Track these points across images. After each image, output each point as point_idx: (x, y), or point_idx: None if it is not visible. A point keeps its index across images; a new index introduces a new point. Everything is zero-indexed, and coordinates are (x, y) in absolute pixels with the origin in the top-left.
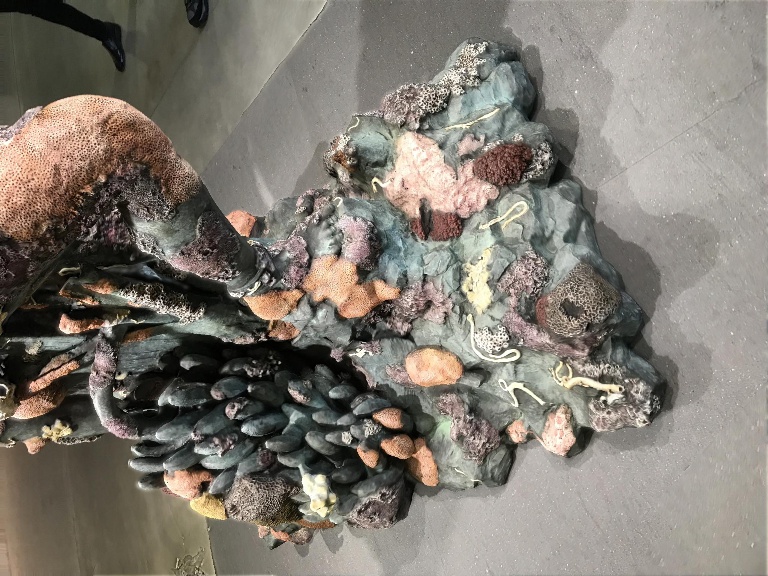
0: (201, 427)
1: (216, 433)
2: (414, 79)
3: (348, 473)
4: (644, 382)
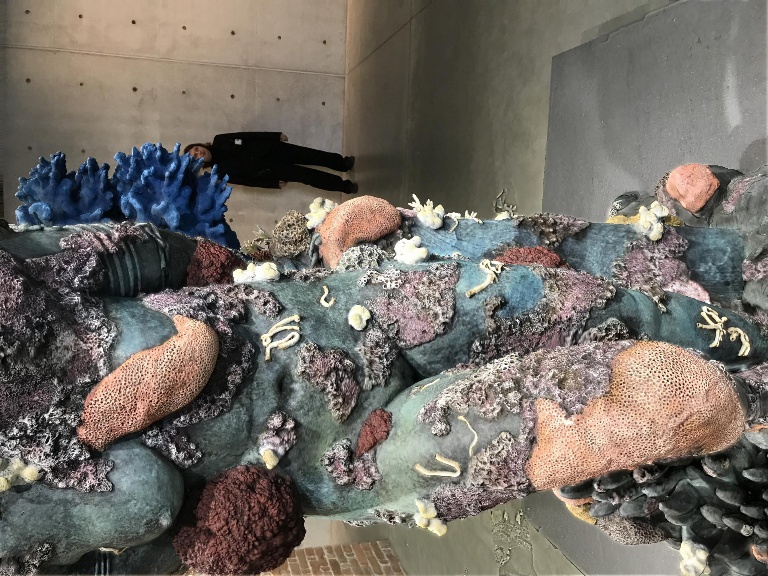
0: (606, 484)
1: (617, 487)
2: None
3: (733, 558)
4: None
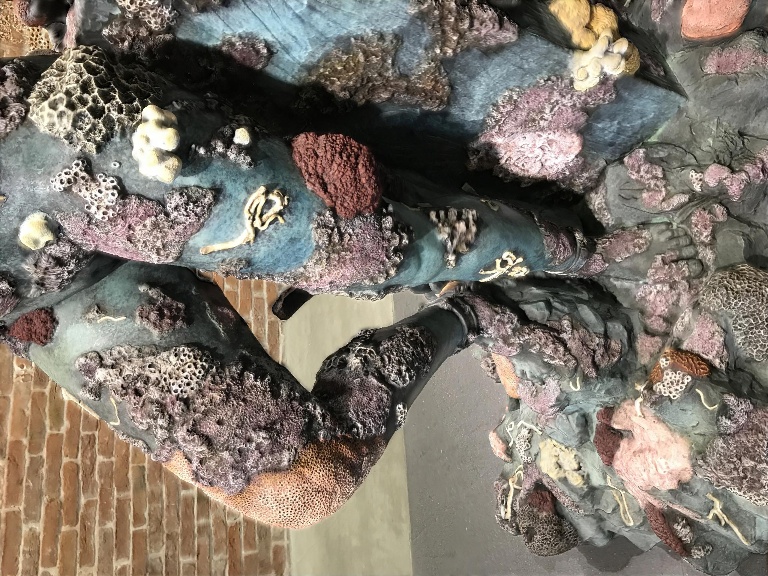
0: None
1: None
2: None
3: None
4: (515, 534)
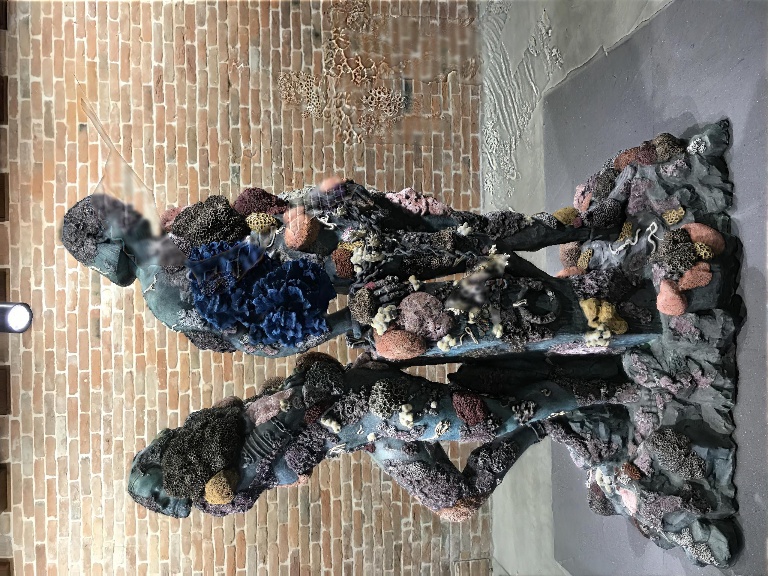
0: None
1: None
2: (767, 495)
3: None
4: None
